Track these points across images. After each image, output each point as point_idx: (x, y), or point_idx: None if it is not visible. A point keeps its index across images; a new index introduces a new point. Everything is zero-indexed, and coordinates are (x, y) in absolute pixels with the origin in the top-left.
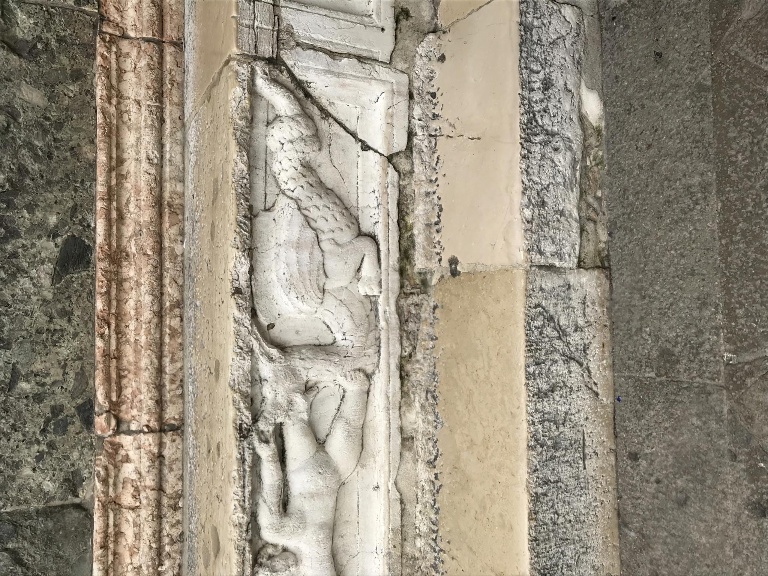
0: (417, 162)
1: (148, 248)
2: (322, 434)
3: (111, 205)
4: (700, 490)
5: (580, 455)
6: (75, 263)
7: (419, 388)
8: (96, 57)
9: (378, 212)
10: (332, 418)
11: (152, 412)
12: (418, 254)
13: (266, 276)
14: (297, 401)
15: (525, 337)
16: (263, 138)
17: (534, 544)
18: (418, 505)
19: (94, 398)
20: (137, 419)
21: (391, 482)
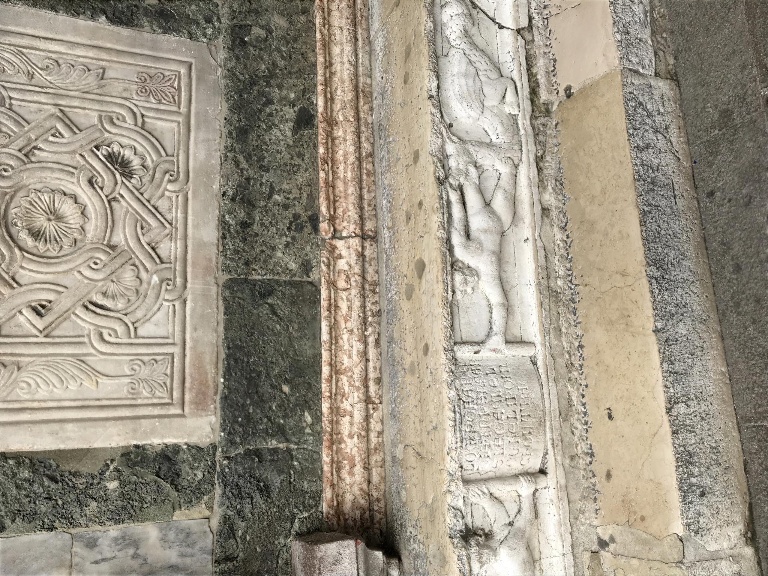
0: (536, 33)
1: (350, 117)
2: (487, 199)
3: (327, 89)
4: (759, 187)
5: (671, 194)
6: (306, 124)
7: (550, 177)
8: (315, 1)
9: (513, 64)
10: (493, 190)
11: (357, 223)
12: (542, 90)
13: (447, 93)
14: (471, 170)
15: (625, 110)
16: (439, 13)
17: (646, 242)
18: (556, 256)
19: (319, 212)
20: (347, 228)
21: (537, 234)
